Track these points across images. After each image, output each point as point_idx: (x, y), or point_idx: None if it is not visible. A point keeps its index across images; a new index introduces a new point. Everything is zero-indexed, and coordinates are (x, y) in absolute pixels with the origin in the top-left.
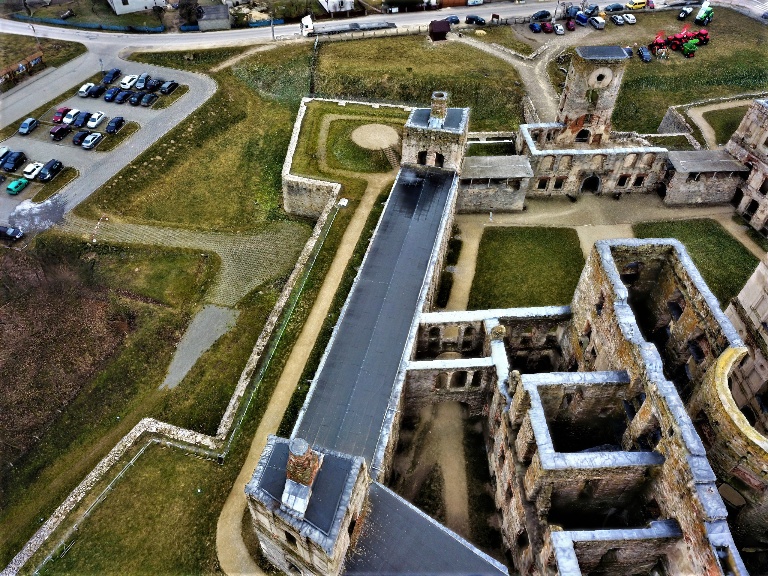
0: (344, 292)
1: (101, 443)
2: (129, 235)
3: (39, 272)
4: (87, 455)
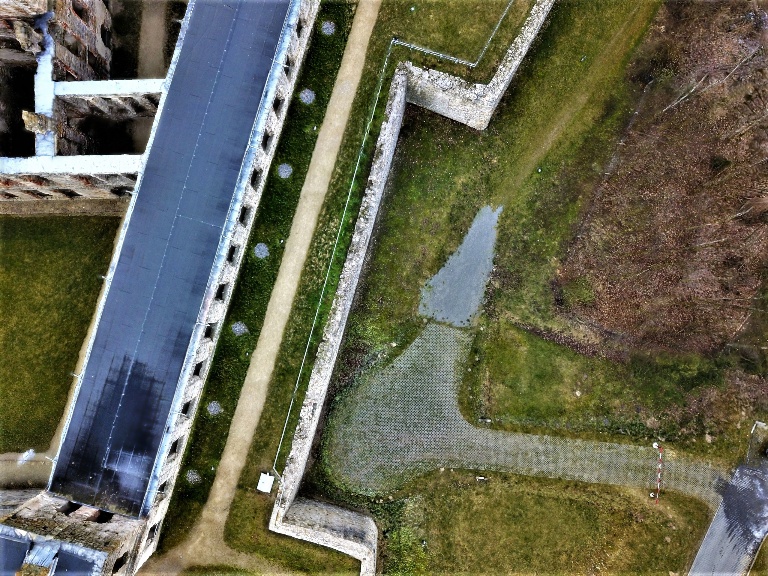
0: (262, 283)
1: (550, 141)
2: (607, 459)
3: (716, 392)
4: (561, 128)
